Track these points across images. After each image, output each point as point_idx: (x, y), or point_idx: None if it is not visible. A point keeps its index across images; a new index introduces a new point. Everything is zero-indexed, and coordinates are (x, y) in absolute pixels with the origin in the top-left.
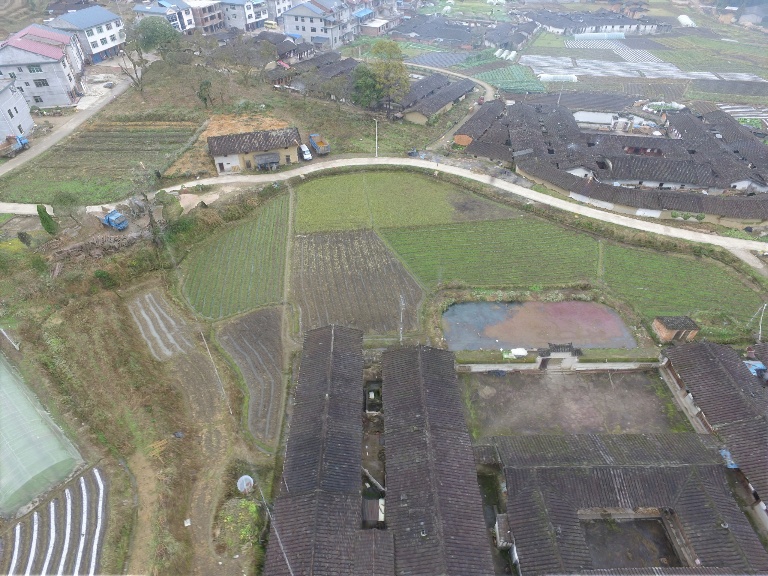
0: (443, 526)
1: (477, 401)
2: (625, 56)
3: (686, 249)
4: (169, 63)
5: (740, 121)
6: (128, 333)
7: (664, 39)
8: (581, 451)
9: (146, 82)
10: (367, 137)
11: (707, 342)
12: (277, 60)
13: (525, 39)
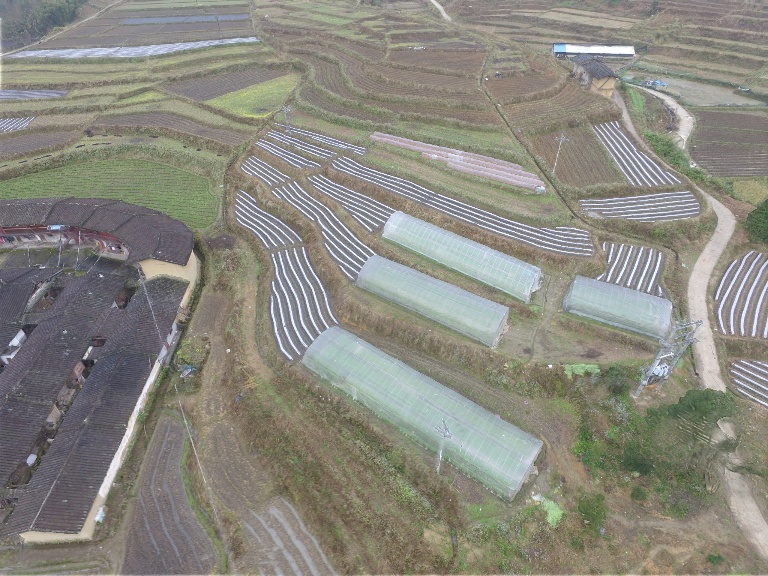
0: (49, 334)
1: None
2: None
3: None
4: None
5: None
6: (325, 523)
7: None
8: None
9: None
10: None
11: None
12: None
13: None
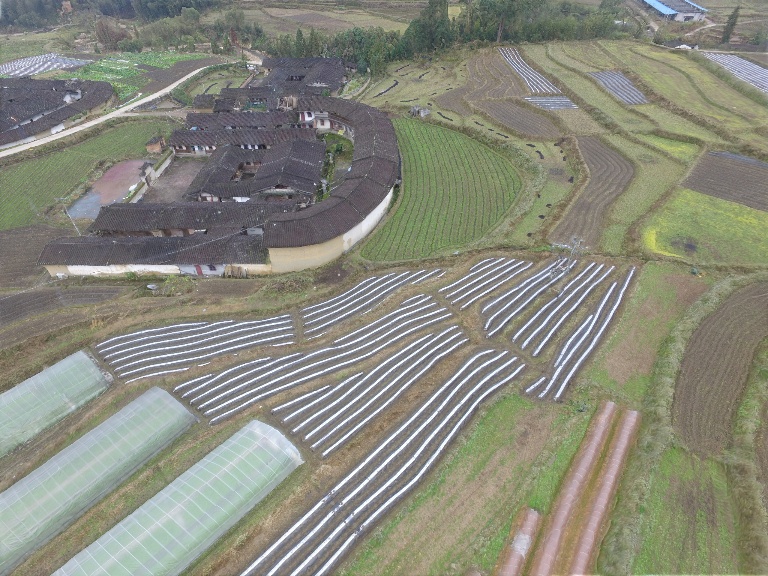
0: None
1: None
2: None
3: (104, 127)
4: None
5: None
6: None
7: None
8: (206, 173)
9: None
10: None
11: None
12: None
13: None
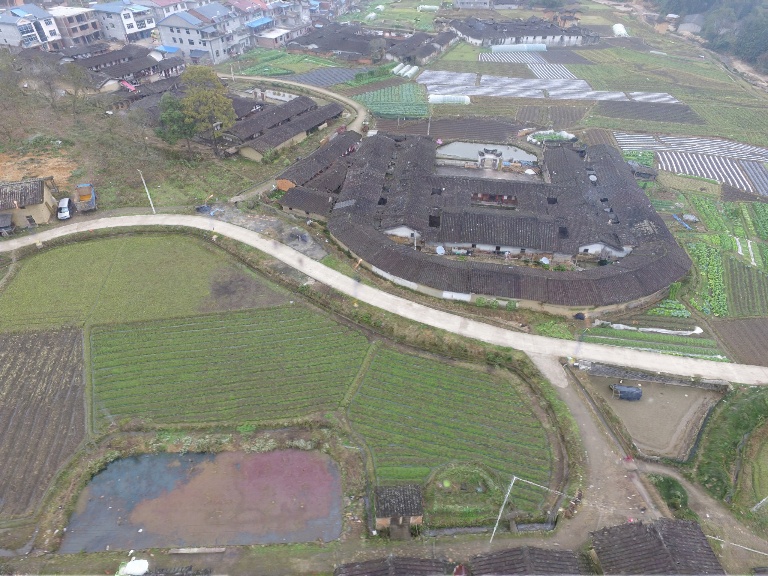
0: None
1: None
2: (538, 72)
3: (479, 355)
4: None
5: (631, 155)
6: None
7: (588, 51)
8: None
9: None
10: (173, 182)
11: (396, 560)
12: (120, 80)
13: (435, 52)
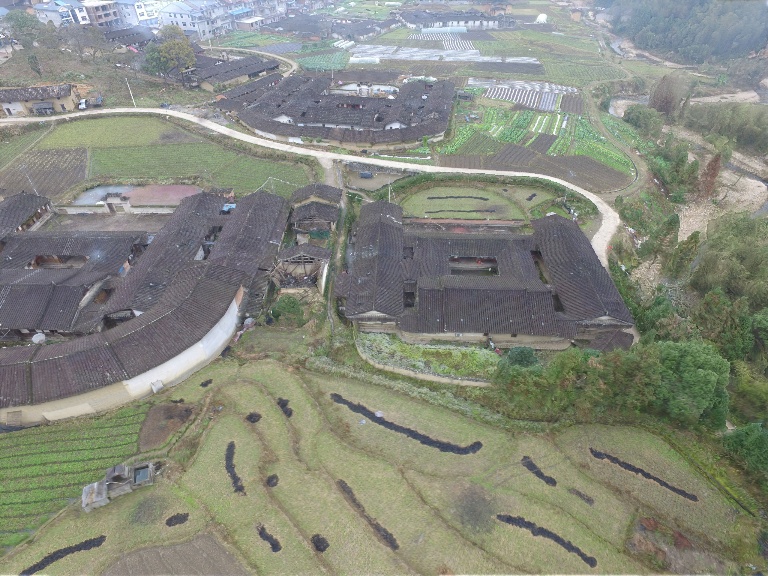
0: None
1: (56, 226)
2: (447, 45)
3: (292, 159)
4: (23, 45)
5: (469, 89)
6: None
7: (500, 32)
8: (66, 234)
9: (8, 61)
10: None
11: (205, 193)
12: (127, 46)
13: (374, 32)
